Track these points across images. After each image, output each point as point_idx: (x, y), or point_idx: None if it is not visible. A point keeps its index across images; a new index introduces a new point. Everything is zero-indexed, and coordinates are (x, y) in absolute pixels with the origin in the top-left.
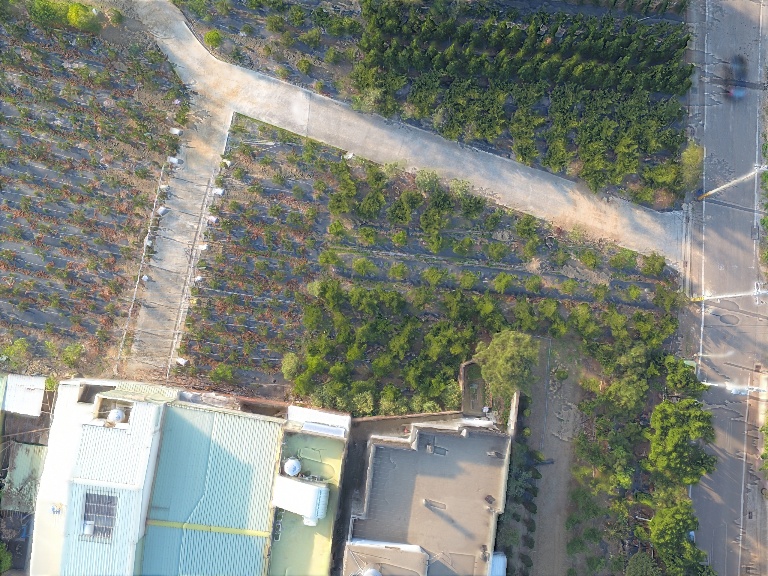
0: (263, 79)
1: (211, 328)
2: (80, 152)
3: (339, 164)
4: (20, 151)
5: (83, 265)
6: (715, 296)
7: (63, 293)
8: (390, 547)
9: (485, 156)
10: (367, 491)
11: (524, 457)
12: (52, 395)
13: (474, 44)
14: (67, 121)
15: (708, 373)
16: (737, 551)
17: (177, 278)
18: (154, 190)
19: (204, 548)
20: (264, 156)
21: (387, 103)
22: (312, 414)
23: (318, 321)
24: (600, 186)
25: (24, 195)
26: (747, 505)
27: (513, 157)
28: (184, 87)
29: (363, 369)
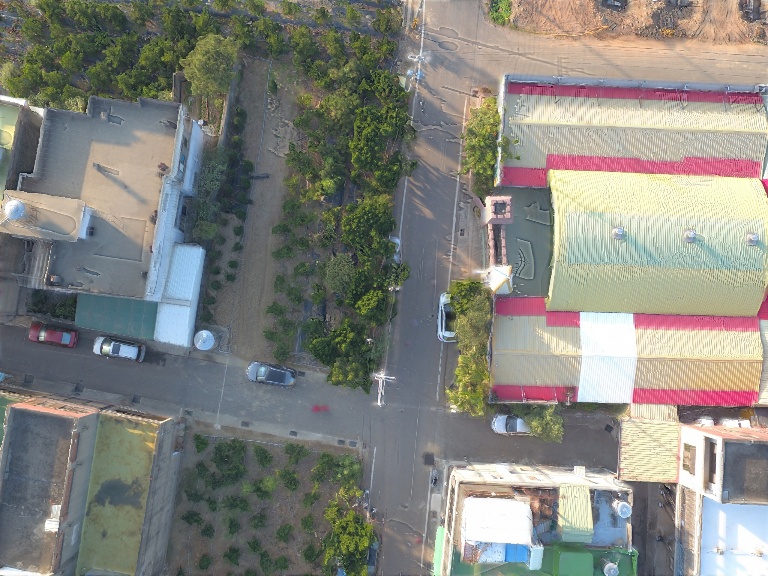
0: None
1: None
2: None
3: None
4: None
5: None
6: None
7: None
8: None
9: None
10: (37, 151)
11: (226, 157)
12: None
13: None
14: None
15: (425, 96)
16: (447, 266)
17: None
18: None
19: None
20: None
21: None
22: None
23: (34, 30)
24: None
25: None
26: (459, 223)
27: None
28: None
29: (84, 83)
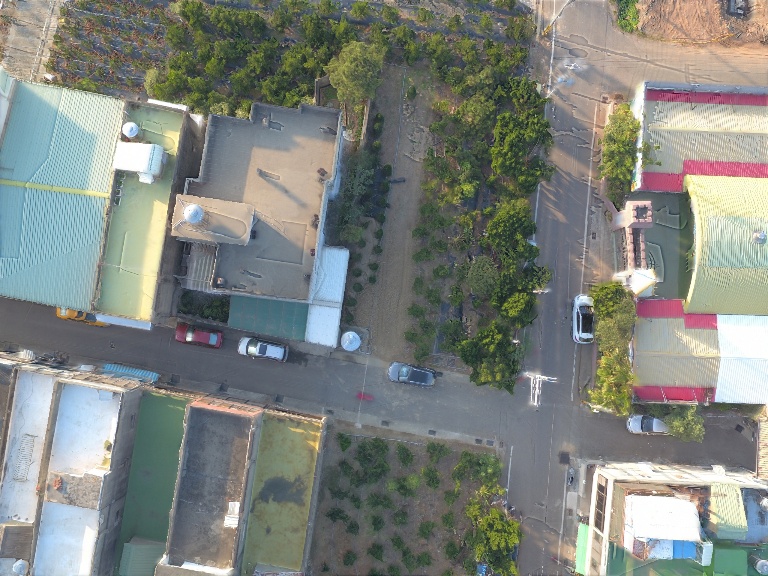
0: None
1: (79, 47)
2: None
3: None
4: None
5: None
6: (557, 15)
7: None
8: None
9: None
10: (202, 156)
11: (370, 162)
12: None
13: None
14: None
15: (556, 102)
16: (580, 268)
17: None
18: None
19: (46, 207)
20: None
21: None
22: None
23: (179, 37)
24: None
25: None
26: (591, 226)
27: None
28: None
29: (224, 89)
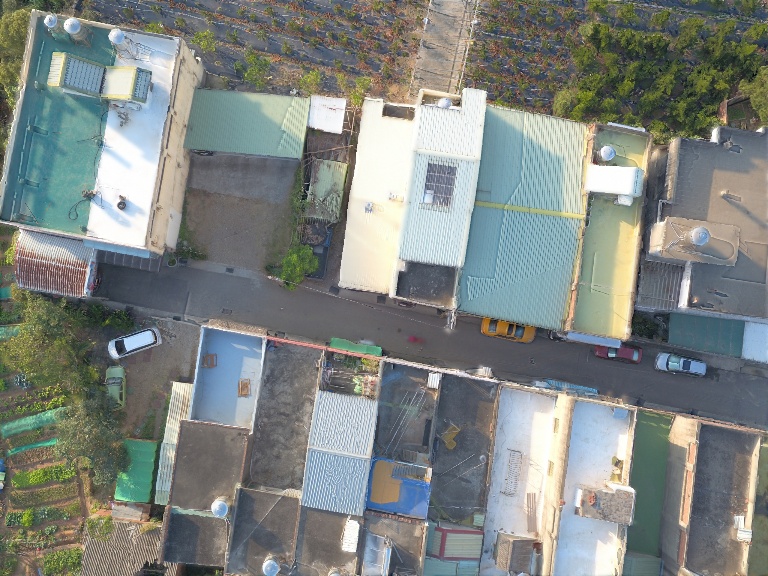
0: None
1: (485, 69)
2: None
3: None
4: None
5: (367, 8)
6: None
7: (349, 33)
8: None
9: None
10: (673, 178)
11: None
12: (352, 115)
13: None
14: None
15: None
16: None
17: (454, 22)
18: None
19: (523, 229)
20: None
21: None
22: None
23: None
24: None
25: None
26: None
27: None
28: None
29: (626, 110)
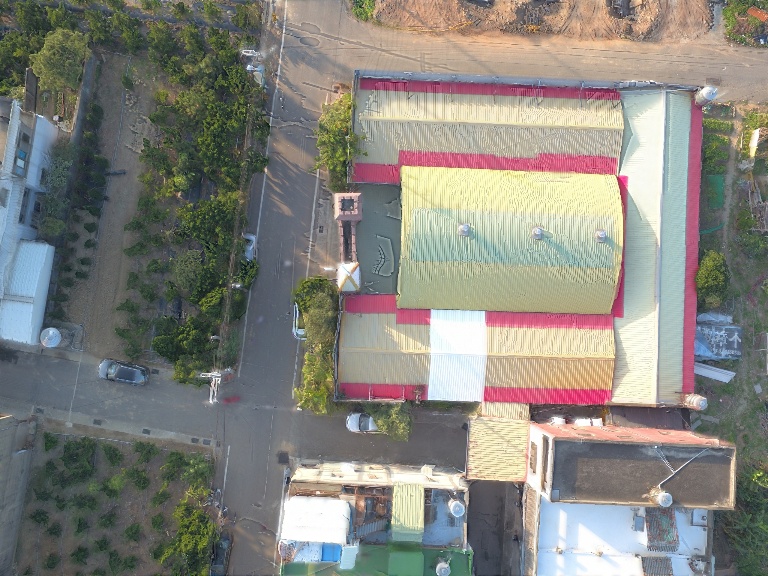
0: None
1: None
2: None
3: None
4: None
5: None
6: None
7: None
8: None
9: None
10: None
11: (75, 153)
12: None
13: None
14: None
15: (285, 91)
16: (305, 263)
17: None
18: None
19: None
20: None
21: None
22: None
23: None
24: None
25: None
26: (318, 219)
27: None
28: None
29: None
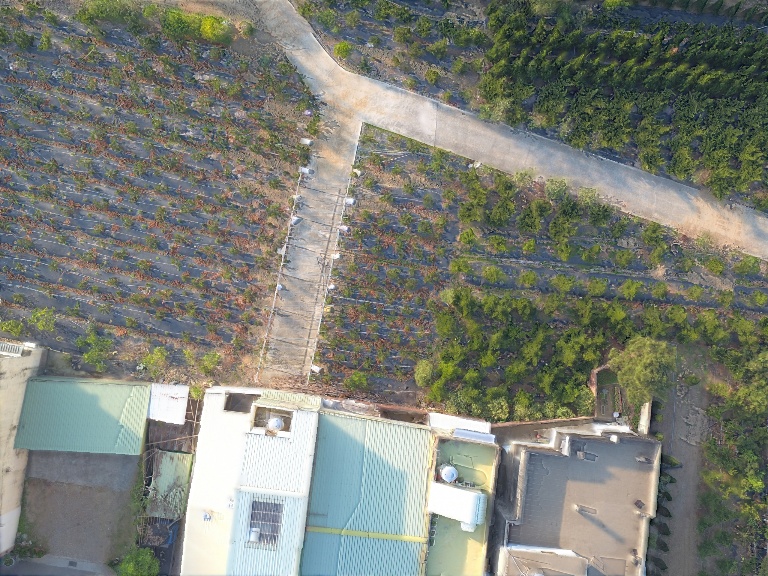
0: (391, 89)
1: (344, 336)
2: (212, 163)
3: (469, 173)
4: (153, 162)
5: (217, 274)
6: None
7: (198, 302)
8: (546, 552)
9: (610, 164)
10: (522, 497)
11: None
12: (195, 403)
13: (598, 54)
14: (199, 132)
15: None
16: None
17: (310, 287)
18: (286, 200)
19: (362, 554)
20: (394, 166)
21: (516, 113)
22: (453, 421)
23: (452, 329)
24: (725, 193)
25: (158, 206)
26: None
27: (637, 165)
28: (313, 98)
29: (494, 375)
